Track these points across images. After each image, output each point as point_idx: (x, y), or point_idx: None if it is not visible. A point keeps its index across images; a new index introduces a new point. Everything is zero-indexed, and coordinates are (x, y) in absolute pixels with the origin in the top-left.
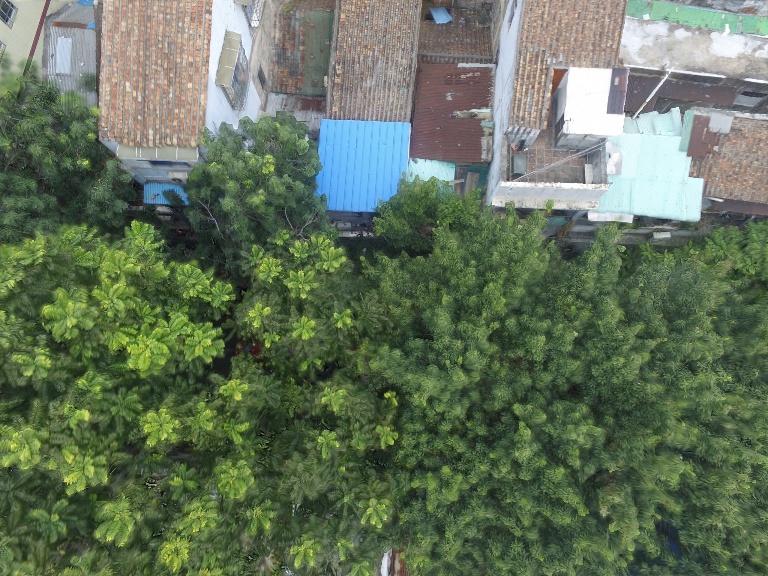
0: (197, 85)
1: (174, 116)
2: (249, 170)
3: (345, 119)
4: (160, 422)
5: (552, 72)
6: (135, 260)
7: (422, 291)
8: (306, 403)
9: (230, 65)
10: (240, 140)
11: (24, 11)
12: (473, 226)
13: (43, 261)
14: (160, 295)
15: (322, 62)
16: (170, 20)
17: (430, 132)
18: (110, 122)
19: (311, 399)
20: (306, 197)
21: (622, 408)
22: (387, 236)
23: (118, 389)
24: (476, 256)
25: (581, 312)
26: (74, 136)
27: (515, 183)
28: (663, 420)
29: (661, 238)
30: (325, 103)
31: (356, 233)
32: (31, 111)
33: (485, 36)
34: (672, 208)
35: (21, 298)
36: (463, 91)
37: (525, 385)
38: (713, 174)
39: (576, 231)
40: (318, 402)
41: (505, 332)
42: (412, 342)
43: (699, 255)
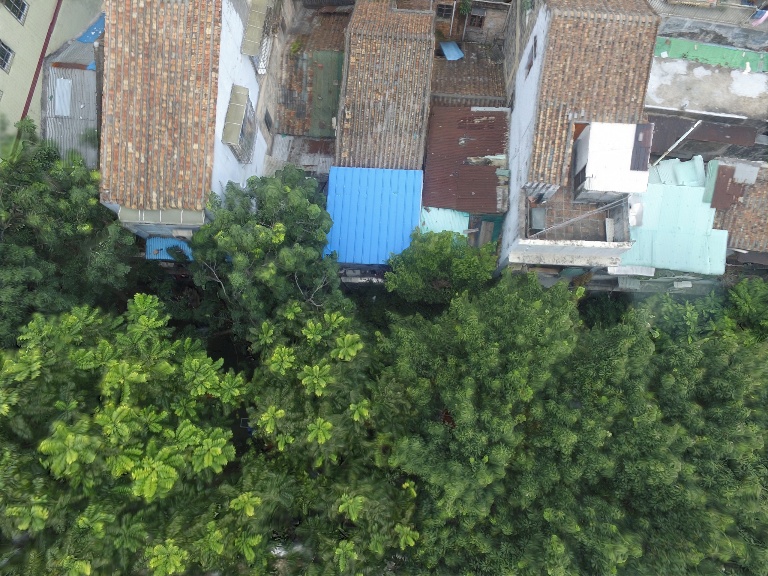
0: (203, 146)
1: (179, 178)
2: (258, 242)
3: (355, 165)
4: (167, 552)
5: (573, 127)
6: (140, 366)
7: (440, 365)
8: (321, 503)
9: (237, 121)
10: (248, 201)
11: (22, 54)
12: (493, 294)
13: (41, 374)
14: (166, 392)
15: (330, 103)
16: (175, 78)
17: (443, 179)
18: (112, 184)
19: (327, 500)
20: (317, 259)
21: (657, 507)
22: (399, 291)
23: (122, 517)
24: (497, 328)
25: (612, 402)
26: (74, 201)
27: (534, 241)
28: (705, 532)
29: (682, 287)
30: (333, 145)
31: (365, 279)
32: (29, 174)
33: (498, 74)
34: (695, 261)
35: (17, 422)
36: (477, 136)
37: (553, 481)
38: (737, 225)
39: (593, 279)
40: (335, 509)
41: (530, 417)
42: (432, 429)
43: (722, 307)
